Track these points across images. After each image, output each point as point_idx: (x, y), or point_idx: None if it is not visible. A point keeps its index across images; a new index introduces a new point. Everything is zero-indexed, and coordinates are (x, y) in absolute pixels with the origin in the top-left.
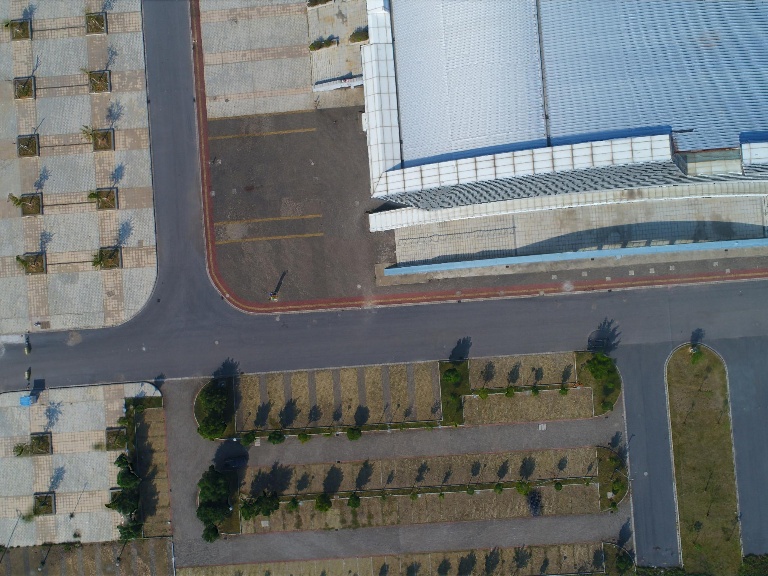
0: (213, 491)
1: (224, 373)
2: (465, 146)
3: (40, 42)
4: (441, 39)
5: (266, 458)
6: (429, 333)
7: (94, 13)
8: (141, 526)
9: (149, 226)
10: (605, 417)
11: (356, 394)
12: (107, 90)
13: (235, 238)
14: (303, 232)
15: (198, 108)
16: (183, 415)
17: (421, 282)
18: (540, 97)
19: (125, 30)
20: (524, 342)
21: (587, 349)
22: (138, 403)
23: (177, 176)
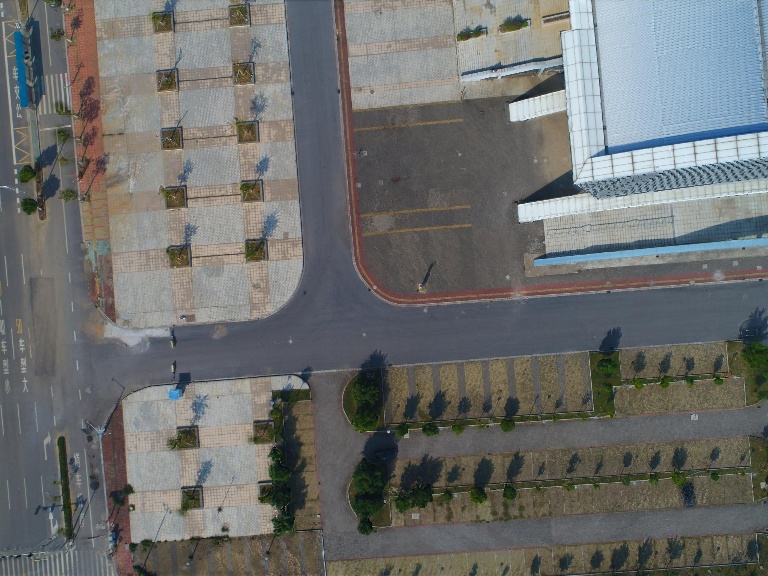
0: (371, 483)
1: (372, 365)
2: (678, 131)
3: (183, 34)
4: (651, 24)
5: (416, 450)
6: (579, 324)
7: (237, 5)
8: (294, 519)
9: (295, 218)
10: (757, 407)
11: (506, 385)
12: (251, 82)
13: (382, 230)
14: (451, 223)
15: (343, 99)
16: (331, 408)
17: (570, 272)
18: (761, 81)
19: (268, 22)
20: (675, 332)
21: (738, 339)
22: (286, 396)
23: (322, 168)
